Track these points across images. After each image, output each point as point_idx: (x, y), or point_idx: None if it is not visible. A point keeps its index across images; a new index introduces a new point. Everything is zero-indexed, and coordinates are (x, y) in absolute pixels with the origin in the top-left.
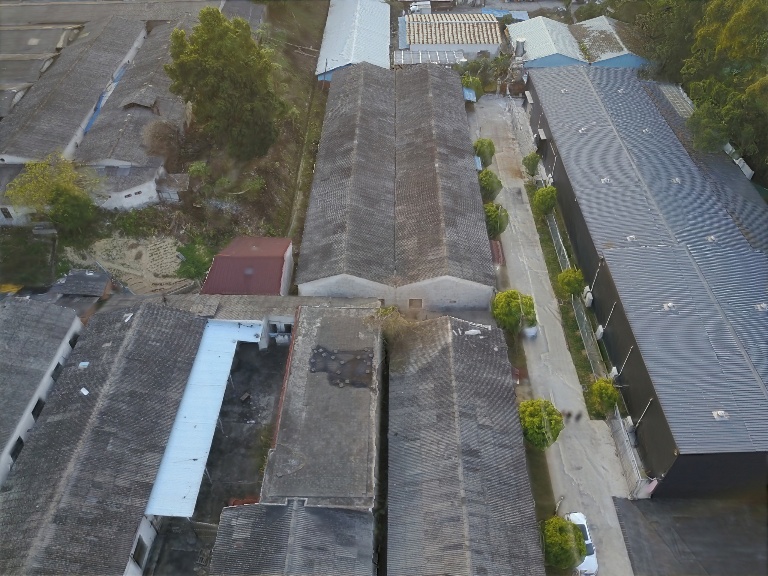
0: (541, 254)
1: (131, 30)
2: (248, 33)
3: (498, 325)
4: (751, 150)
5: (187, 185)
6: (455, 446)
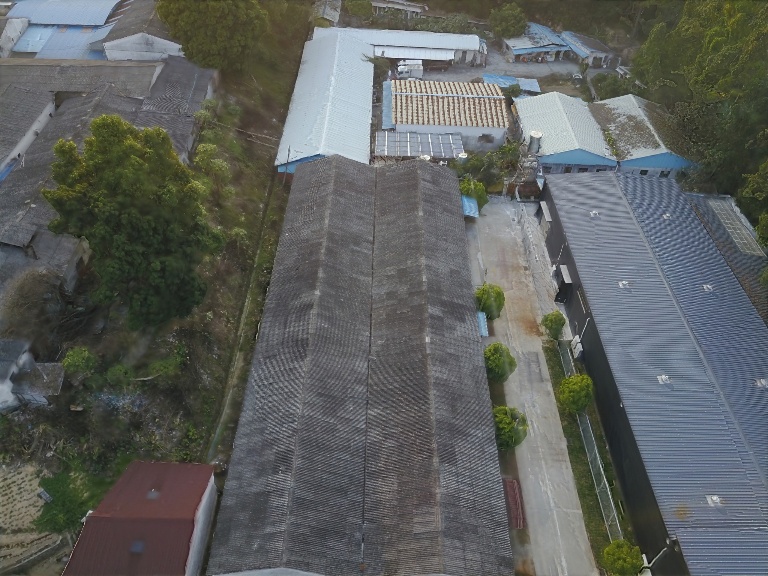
0: (571, 477)
1: (31, 106)
2: (167, 148)
3: None
4: None
5: (59, 385)
6: None
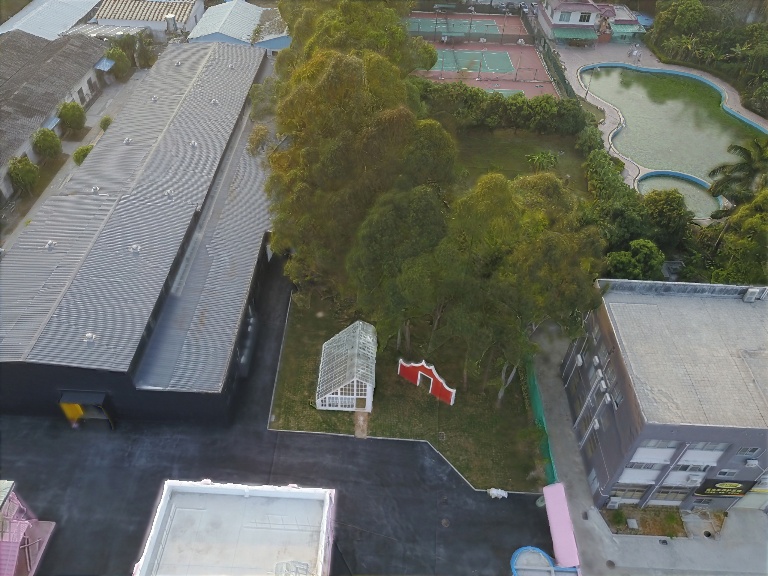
0: None
1: None
2: None
3: None
4: None
5: None
6: None
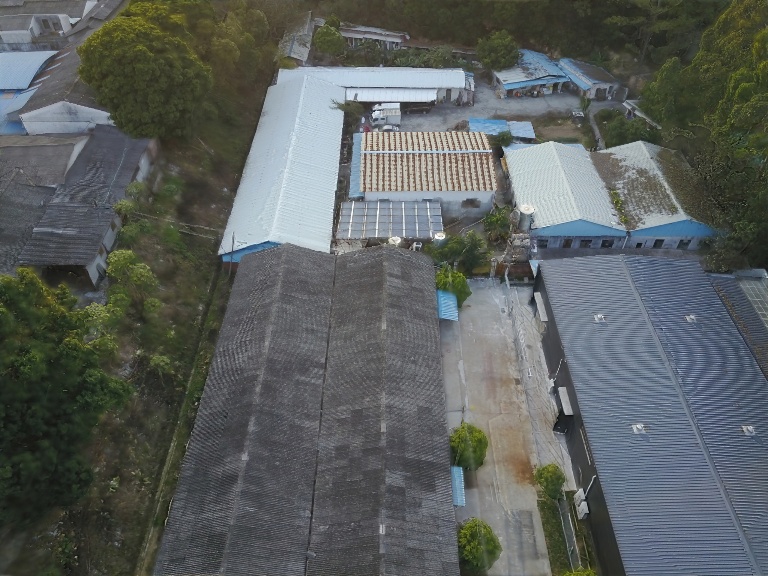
0: None
1: None
2: (33, 295)
3: None
4: None
5: None
6: None
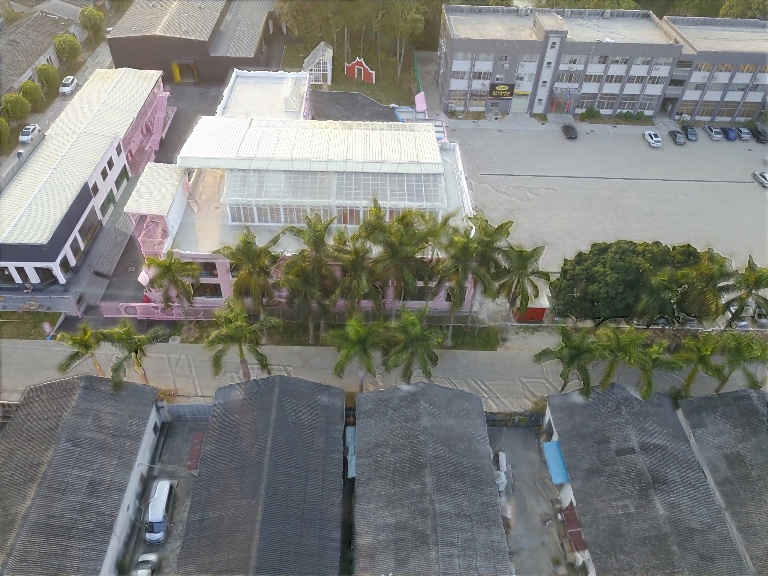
0: None
1: None
2: None
3: (80, 24)
4: None
5: None
6: (7, 39)
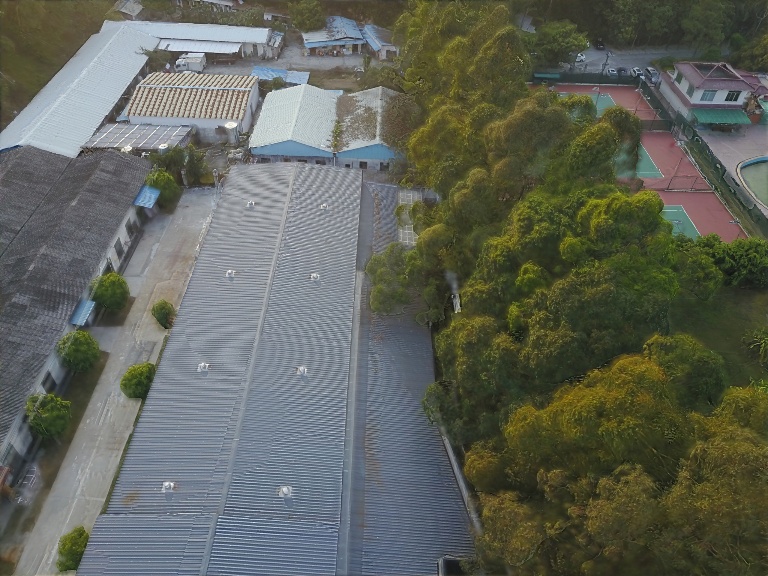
0: (115, 465)
1: None
2: None
3: None
4: (433, 317)
5: None
6: None
